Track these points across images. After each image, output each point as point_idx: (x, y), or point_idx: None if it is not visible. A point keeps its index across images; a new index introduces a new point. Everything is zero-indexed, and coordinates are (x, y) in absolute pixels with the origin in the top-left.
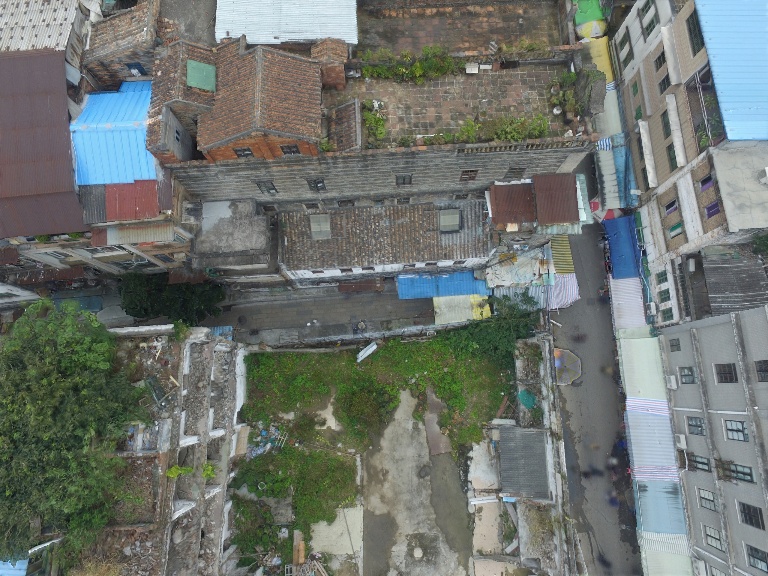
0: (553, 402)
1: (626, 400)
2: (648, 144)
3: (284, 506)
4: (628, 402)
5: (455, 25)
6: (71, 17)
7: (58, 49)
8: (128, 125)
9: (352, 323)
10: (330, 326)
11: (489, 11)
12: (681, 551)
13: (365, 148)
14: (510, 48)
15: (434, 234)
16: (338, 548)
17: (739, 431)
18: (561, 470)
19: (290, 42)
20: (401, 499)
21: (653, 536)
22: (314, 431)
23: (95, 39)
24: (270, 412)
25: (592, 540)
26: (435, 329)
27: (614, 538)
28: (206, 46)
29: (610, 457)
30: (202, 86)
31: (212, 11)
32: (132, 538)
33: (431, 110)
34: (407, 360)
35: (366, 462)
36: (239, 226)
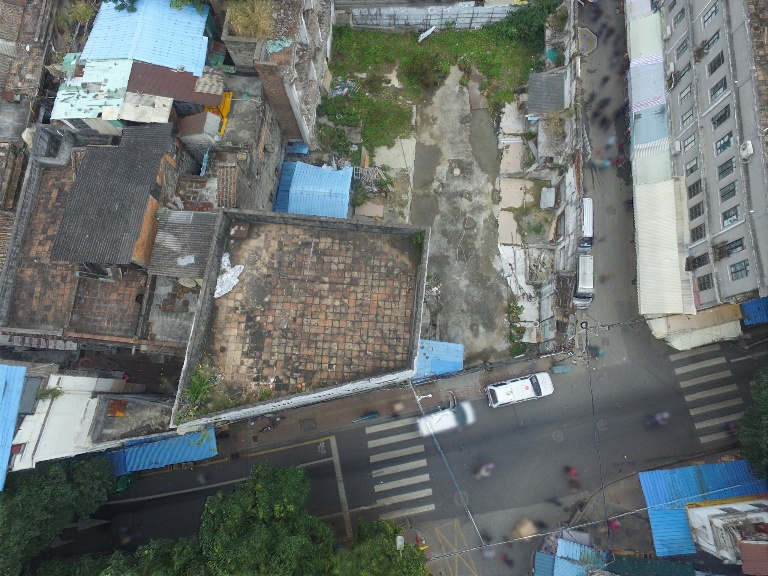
0: (574, 34)
1: (630, 62)
2: None
3: (355, 133)
4: (632, 63)
5: None
6: None
7: None
8: None
9: None
10: None
11: None
12: (663, 149)
13: None
14: None
15: None
16: (395, 164)
17: (713, 13)
18: (576, 75)
19: None
20: (446, 136)
21: (642, 146)
22: (381, 86)
23: None
24: (348, 72)
25: (594, 174)
26: (482, 22)
27: (611, 174)
28: None
29: (614, 121)
30: None
31: None
32: (279, 6)
33: None
34: (458, 44)
35: (420, 111)
36: None
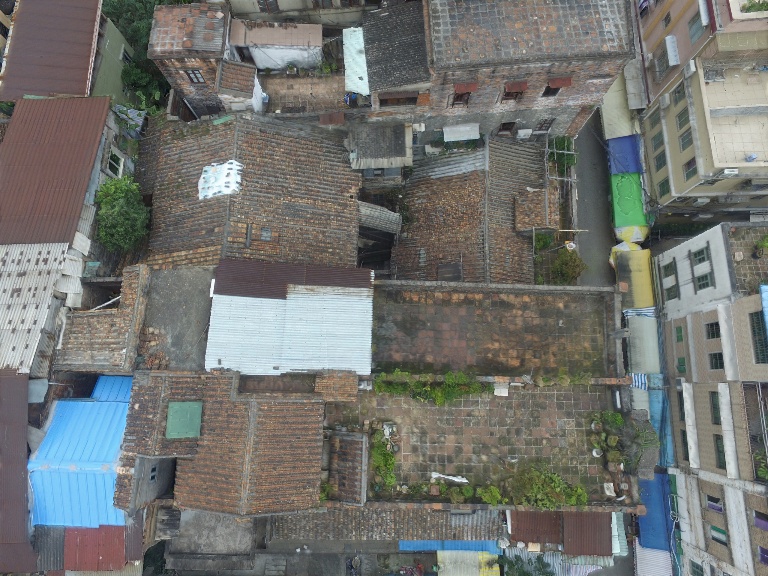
0: None
1: None
2: (691, 412)
3: None
4: None
5: (485, 318)
6: (41, 320)
7: (21, 371)
8: (95, 469)
9: (346, 554)
10: (321, 555)
11: (525, 302)
12: None
13: (371, 487)
14: (548, 383)
15: (443, 514)
16: None
17: None
18: None
19: (292, 372)
20: None
21: None
22: None
23: (69, 336)
24: None
25: None
26: None
27: None
28: (194, 372)
29: None
30: (184, 434)
31: (205, 319)
32: None
33: (450, 438)
34: None
35: None
36: (223, 519)
